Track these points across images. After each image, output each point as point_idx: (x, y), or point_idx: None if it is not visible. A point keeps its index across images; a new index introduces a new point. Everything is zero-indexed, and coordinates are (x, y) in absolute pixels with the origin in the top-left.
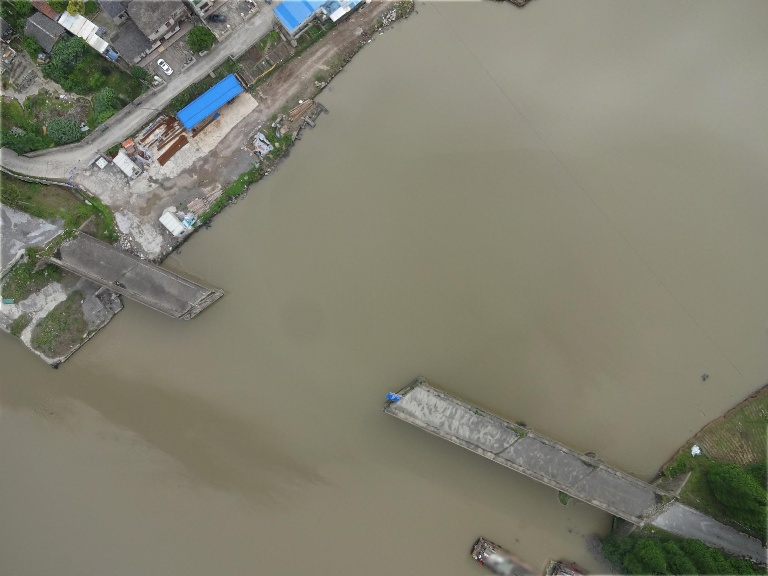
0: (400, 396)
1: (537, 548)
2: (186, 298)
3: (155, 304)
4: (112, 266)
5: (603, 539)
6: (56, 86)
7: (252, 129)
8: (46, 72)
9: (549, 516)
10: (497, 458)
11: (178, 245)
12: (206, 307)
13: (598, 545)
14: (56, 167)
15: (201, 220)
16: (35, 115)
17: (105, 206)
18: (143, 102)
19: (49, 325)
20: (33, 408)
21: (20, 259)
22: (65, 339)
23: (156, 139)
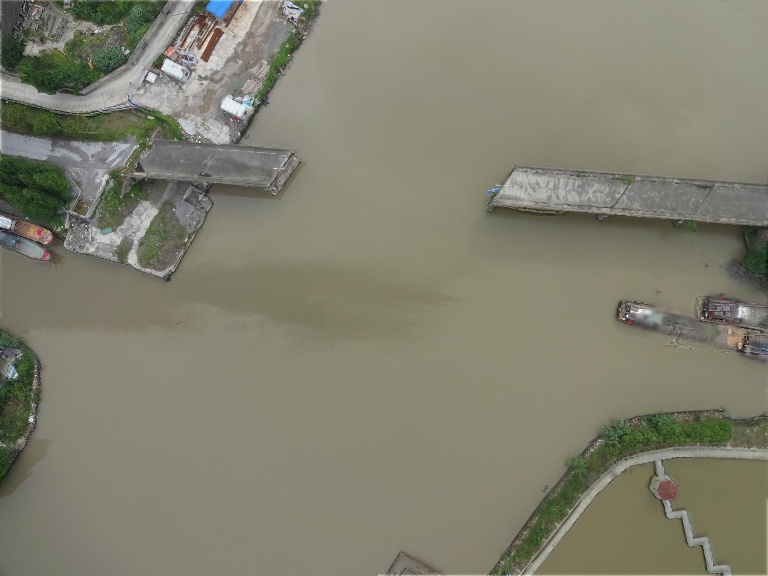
0: (501, 185)
1: (680, 293)
2: (270, 165)
3: (243, 181)
4: (192, 161)
5: (741, 262)
6: (88, 25)
7: (278, 1)
8: (75, 13)
9: (680, 260)
10: (613, 211)
11: (245, 129)
12: (289, 177)
13: (739, 269)
14: (111, 96)
15: (258, 98)
16: (77, 56)
17: (167, 116)
18: (171, 10)
19: (151, 239)
20: (160, 324)
21: (106, 185)
22: (170, 247)
23: (193, 40)
